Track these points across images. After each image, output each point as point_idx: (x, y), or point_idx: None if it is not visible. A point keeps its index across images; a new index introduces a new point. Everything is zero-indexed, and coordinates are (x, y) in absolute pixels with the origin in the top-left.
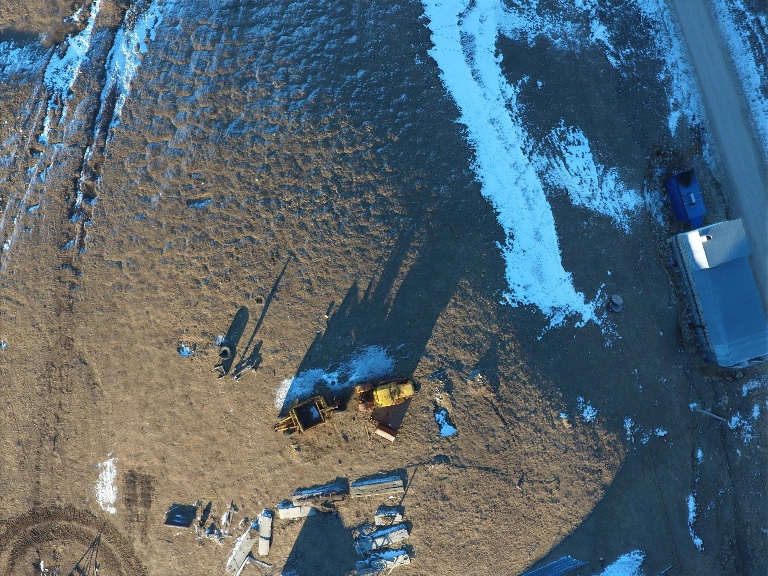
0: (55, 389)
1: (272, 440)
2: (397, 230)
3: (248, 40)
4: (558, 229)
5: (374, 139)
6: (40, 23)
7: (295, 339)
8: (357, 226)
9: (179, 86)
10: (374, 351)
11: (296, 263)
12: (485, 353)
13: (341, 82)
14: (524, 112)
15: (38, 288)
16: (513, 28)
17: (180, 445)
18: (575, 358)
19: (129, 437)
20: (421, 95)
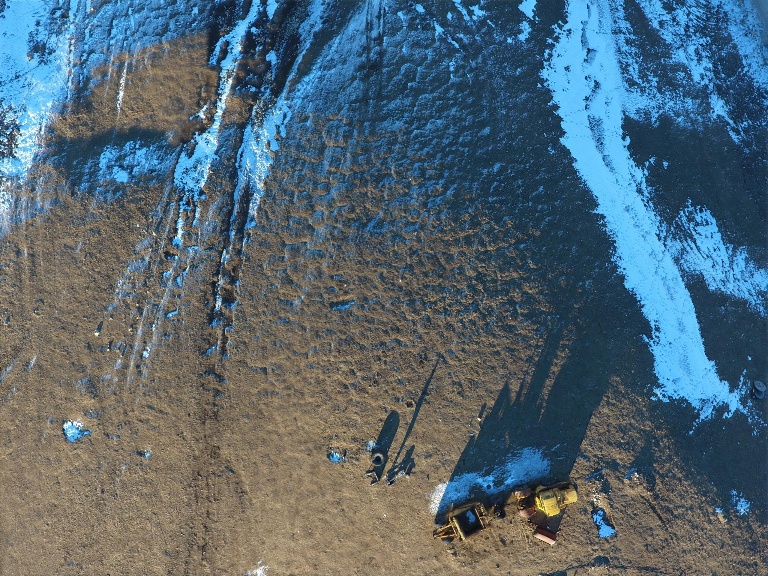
0: (202, 498)
1: (427, 545)
2: (545, 328)
3: (381, 135)
4: (698, 317)
5: (516, 235)
6: (166, 121)
7: (448, 443)
8: (505, 325)
9: (314, 185)
10: (529, 453)
11: (445, 365)
12: (640, 451)
13: (478, 176)
14: (654, 195)
15: (181, 396)
16: (637, 108)
17: (332, 552)
18: (726, 450)
19: (279, 545)
20: (558, 186)
